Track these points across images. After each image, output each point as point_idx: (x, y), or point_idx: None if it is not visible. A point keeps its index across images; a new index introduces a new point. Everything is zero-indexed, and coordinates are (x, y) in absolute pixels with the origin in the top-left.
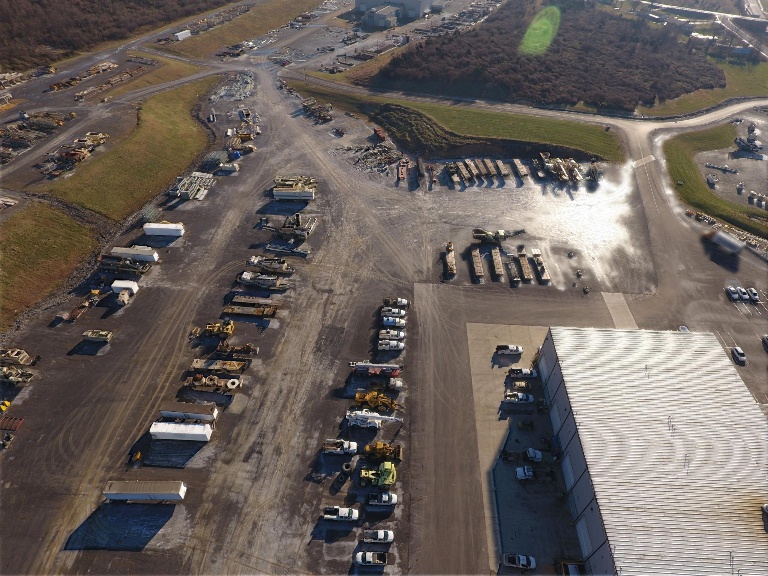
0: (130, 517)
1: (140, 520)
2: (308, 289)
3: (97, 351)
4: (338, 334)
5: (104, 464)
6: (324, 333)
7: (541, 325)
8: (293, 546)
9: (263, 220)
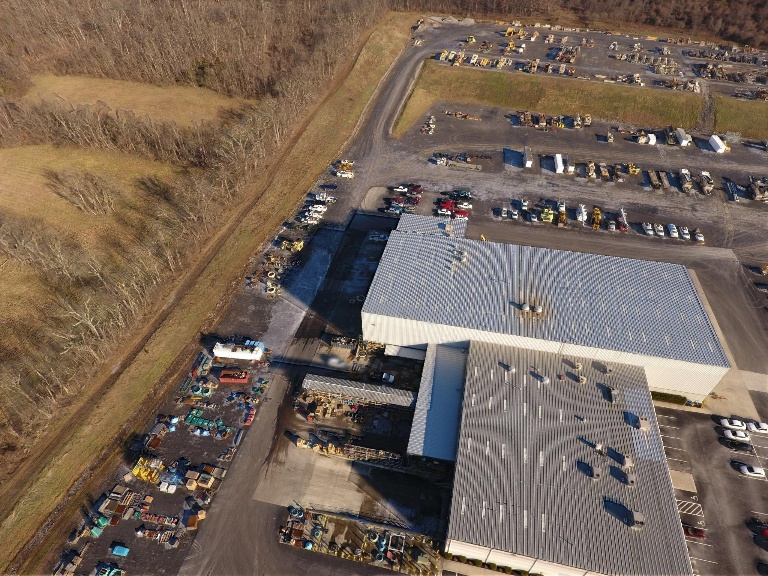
0: (517, 159)
1: (516, 161)
2: (691, 201)
3: (601, 140)
4: (650, 211)
5: (539, 151)
6: (648, 206)
7: (715, 314)
8: (508, 195)
9: (764, 179)
